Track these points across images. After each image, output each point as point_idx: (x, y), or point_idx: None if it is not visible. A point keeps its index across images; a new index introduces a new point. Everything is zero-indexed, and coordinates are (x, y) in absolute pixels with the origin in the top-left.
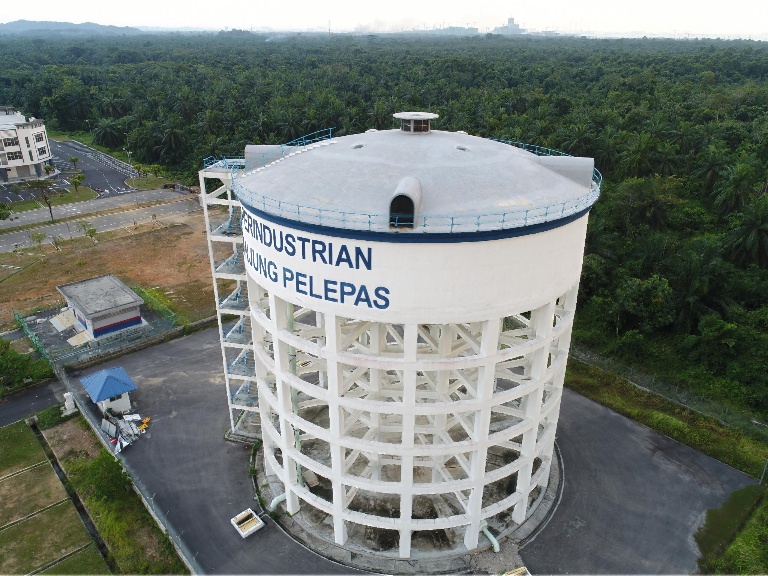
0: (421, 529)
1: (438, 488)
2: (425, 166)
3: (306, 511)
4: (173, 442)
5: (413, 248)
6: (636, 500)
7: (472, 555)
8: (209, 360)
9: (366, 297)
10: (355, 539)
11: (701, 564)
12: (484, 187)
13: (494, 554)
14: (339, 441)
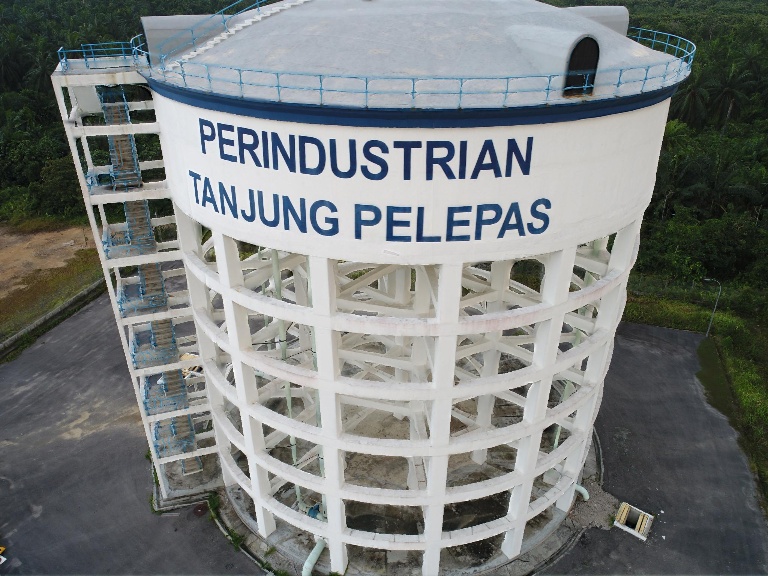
0: (536, 514)
1: (559, 457)
2: (510, 12)
3: (356, 559)
4: (71, 554)
5: (590, 126)
6: (643, 389)
7: (569, 516)
8: (39, 409)
9: (517, 221)
10: (444, 564)
11: (736, 426)
12: (599, 35)
13: (586, 503)
14: (447, 449)
